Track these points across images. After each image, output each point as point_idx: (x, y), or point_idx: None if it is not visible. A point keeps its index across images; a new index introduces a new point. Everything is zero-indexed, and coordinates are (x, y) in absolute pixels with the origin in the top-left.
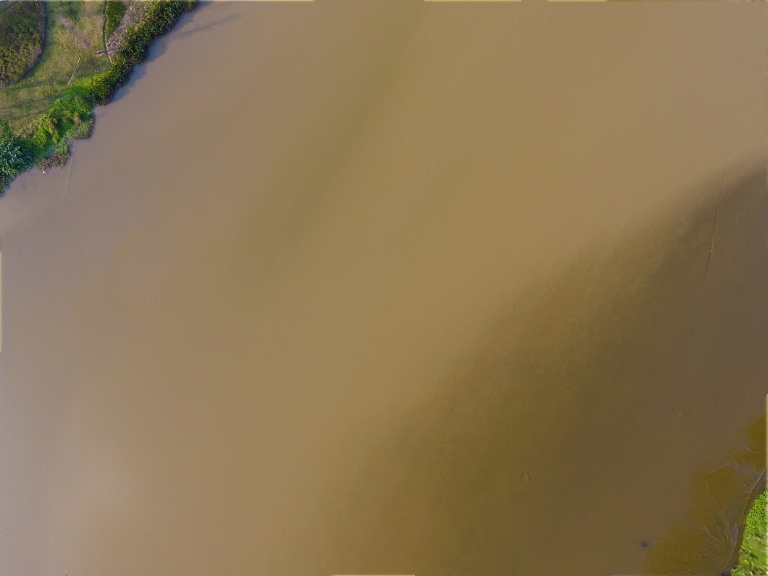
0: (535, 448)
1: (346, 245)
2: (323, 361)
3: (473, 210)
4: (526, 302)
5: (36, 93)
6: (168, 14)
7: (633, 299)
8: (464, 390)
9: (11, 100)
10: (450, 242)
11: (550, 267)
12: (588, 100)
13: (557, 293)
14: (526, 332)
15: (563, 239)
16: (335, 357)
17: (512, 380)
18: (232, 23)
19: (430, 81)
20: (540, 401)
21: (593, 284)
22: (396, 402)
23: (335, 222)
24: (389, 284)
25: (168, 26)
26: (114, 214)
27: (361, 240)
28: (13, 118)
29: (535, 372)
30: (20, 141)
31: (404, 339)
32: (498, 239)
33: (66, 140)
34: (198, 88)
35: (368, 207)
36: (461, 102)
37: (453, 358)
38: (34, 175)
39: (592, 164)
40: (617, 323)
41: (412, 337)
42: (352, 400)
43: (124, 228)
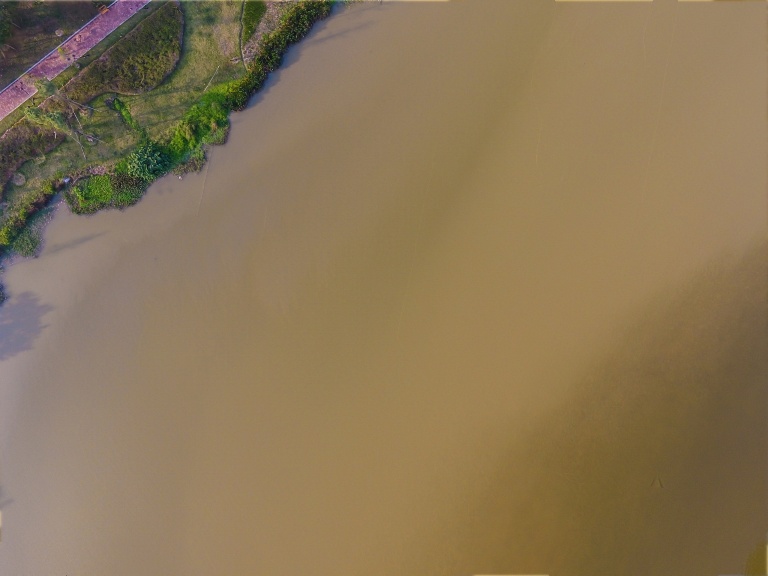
0: (666, 455)
1: (478, 251)
2: (456, 367)
3: (604, 217)
4: (656, 309)
5: (173, 99)
6: (304, 21)
7: (763, 306)
8: (595, 396)
9: (149, 106)
10: (581, 249)
11: (681, 274)
12: (717, 108)
13: (687, 300)
14: (657, 339)
15: (694, 246)
16: (468, 363)
17: (643, 387)
18: (365, 30)
19: (560, 89)
20: (671, 408)
21: (723, 291)
22: (529, 408)
23: (467, 228)
24: (521, 290)
25: (303, 33)
26: (249, 219)
27: (493, 246)
28: (151, 124)
29: (666, 379)
30: (158, 147)
31: (536, 345)
32: (629, 246)
33: (202, 146)
34: (332, 95)
35: (500, 214)
36: (592, 110)
37: (584, 364)
38: (170, 180)
39: (722, 172)
40: (747, 330)
41: (544, 343)
42: (485, 406)
43: (259, 233)
